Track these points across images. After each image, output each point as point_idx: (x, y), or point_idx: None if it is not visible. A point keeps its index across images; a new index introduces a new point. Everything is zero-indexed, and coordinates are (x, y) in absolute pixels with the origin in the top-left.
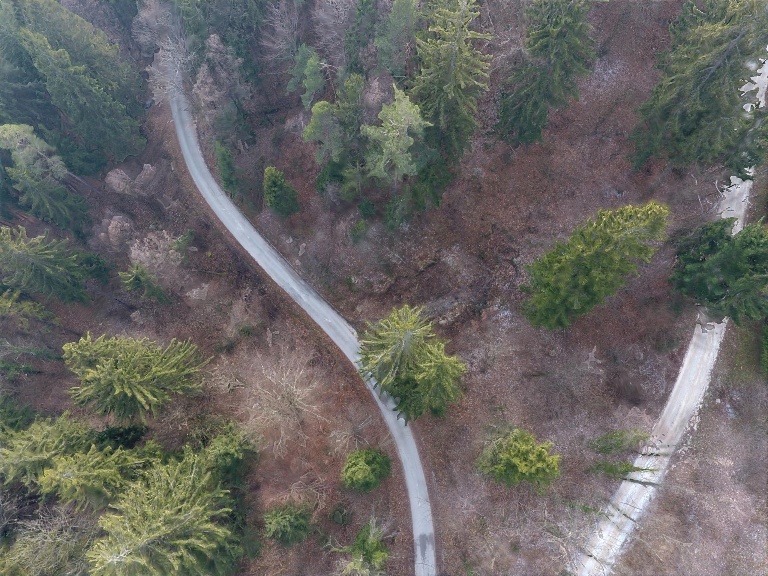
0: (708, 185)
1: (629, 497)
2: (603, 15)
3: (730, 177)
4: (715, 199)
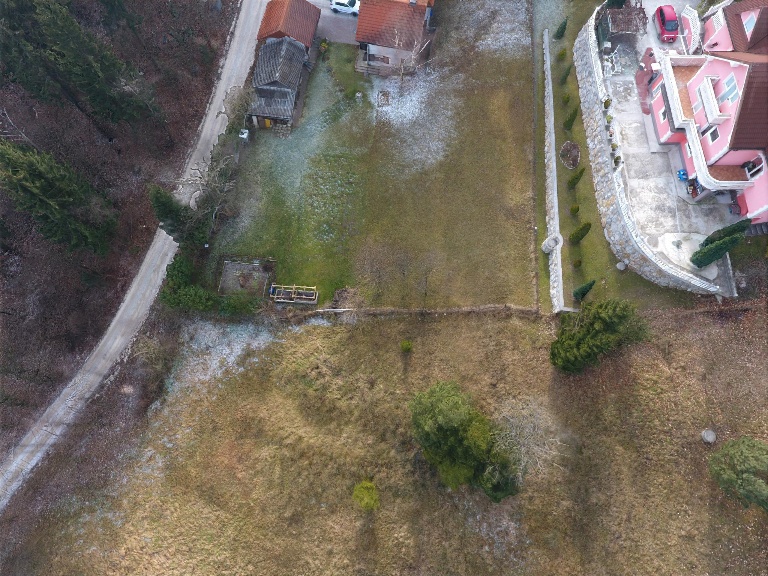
0: None
1: (49, 424)
2: None
3: (209, 124)
4: (189, 145)
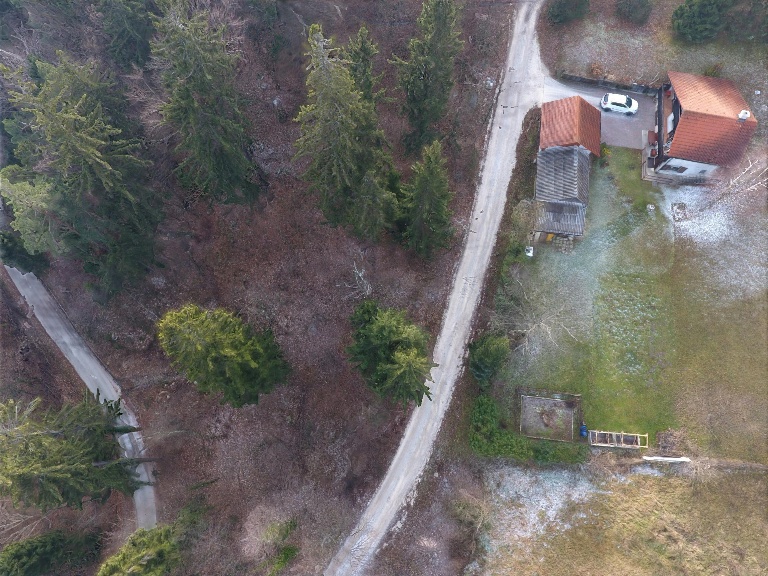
0: None
1: None
2: None
3: (474, 234)
4: (455, 258)
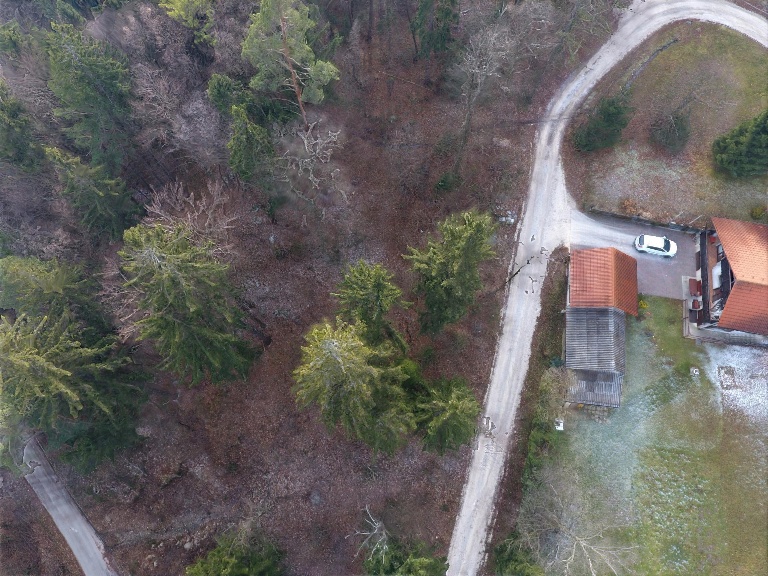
0: None
1: None
2: (360, 194)
3: (495, 394)
4: None
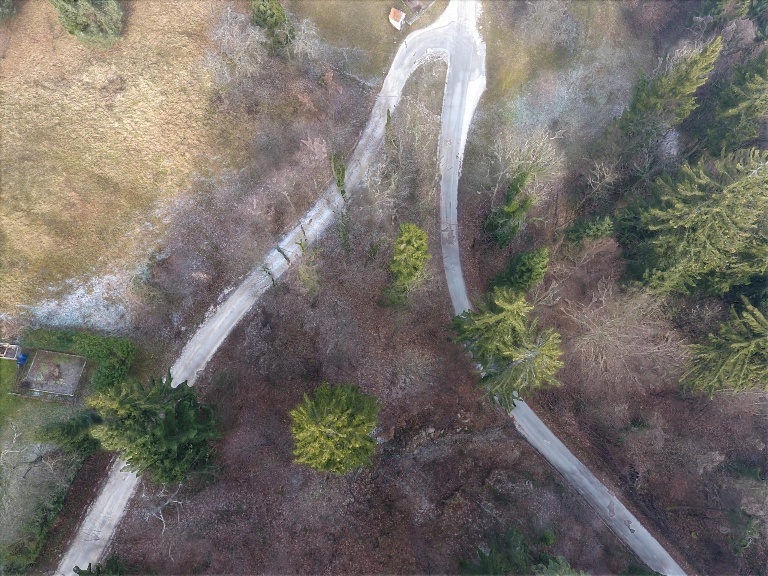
0: (124, 573)
1: None
2: None
3: None
4: (101, 569)
